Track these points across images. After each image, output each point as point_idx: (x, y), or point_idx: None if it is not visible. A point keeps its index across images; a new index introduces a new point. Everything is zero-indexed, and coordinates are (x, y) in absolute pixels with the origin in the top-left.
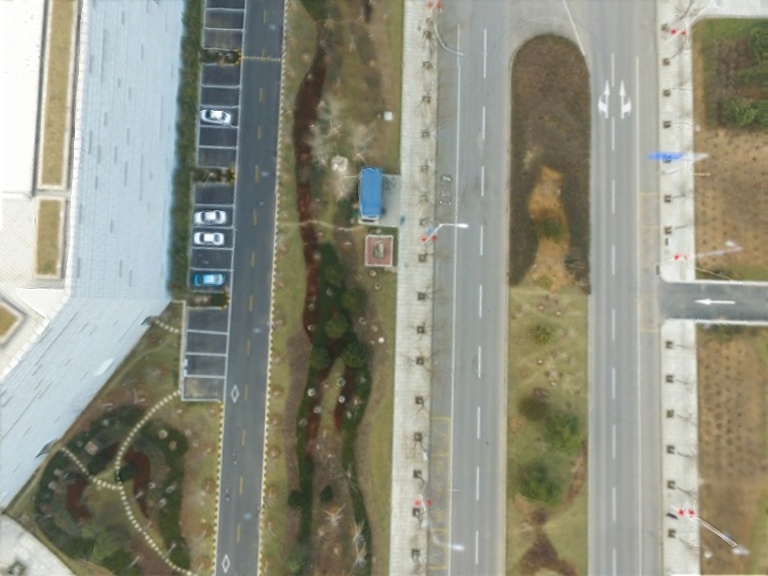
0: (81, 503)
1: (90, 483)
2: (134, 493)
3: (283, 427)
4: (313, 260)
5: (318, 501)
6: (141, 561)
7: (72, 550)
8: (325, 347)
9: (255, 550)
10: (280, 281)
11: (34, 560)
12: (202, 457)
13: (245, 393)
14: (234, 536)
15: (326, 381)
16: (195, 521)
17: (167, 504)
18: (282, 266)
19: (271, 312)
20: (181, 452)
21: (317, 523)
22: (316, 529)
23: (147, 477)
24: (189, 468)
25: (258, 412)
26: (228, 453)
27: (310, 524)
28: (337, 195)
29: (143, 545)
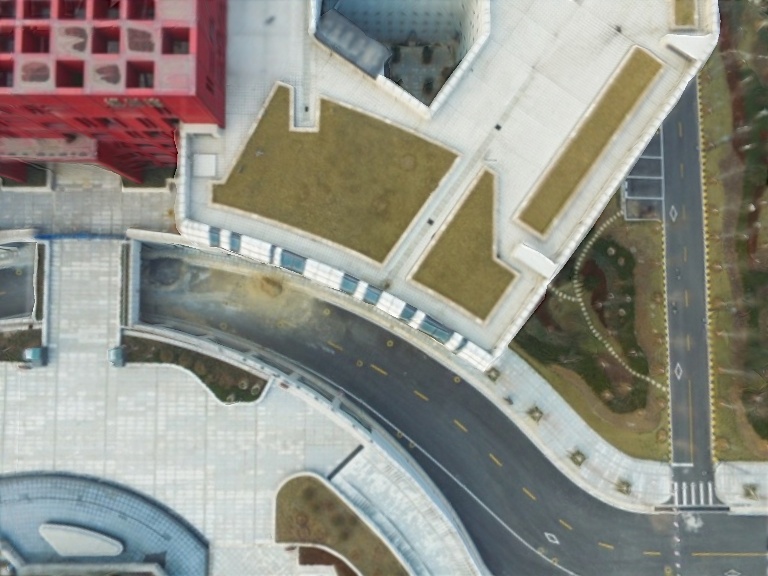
0: (552, 311)
1: (553, 295)
2: (592, 305)
3: (724, 243)
4: (742, 85)
5: (764, 311)
6: (608, 365)
7: (545, 355)
8: (764, 164)
9: (704, 359)
10: (708, 107)
11: (506, 366)
12: (653, 270)
13: (683, 213)
14: (684, 346)
15: (761, 199)
16: (647, 332)
17: (626, 313)
18: (708, 93)
19: (701, 137)
20: (630, 267)
21: (765, 331)
22: (766, 336)
23: (605, 289)
24: (638, 282)
25: (696, 230)
26: (671, 269)
27: (759, 332)
28: (758, 23)
29: (605, 352)
